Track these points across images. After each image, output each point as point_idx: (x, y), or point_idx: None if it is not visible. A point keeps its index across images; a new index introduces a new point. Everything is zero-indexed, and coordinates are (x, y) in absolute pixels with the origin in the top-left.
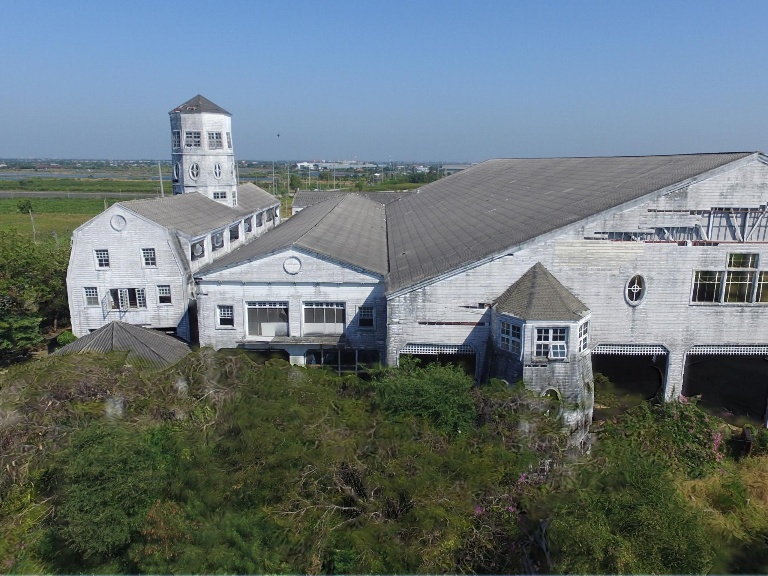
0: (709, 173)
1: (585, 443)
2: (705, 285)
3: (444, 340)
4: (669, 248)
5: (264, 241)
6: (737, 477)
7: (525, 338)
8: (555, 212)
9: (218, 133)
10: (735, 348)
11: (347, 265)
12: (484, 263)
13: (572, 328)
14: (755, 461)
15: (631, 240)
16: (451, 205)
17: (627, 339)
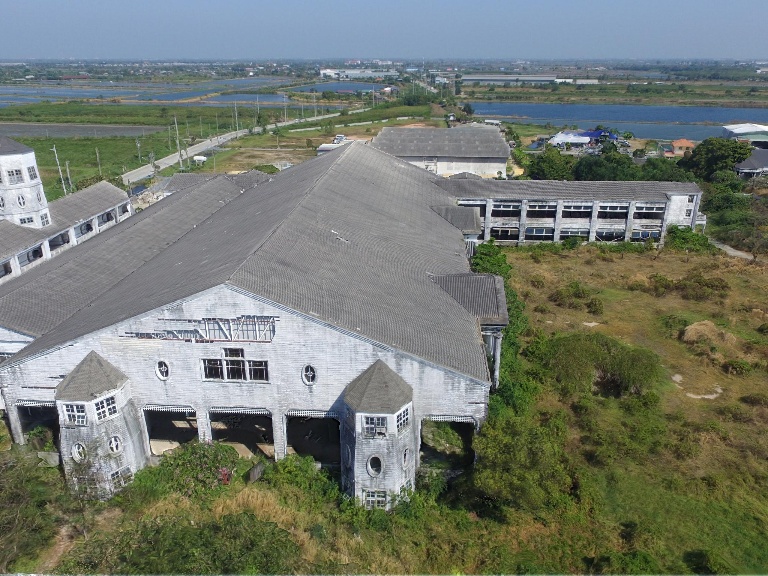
0: (193, 296)
1: (121, 474)
2: (212, 368)
3: (42, 398)
4: (180, 344)
5: (24, 277)
6: (213, 501)
7: (59, 410)
8: (144, 299)
9: (18, 170)
10: (243, 409)
11: (11, 330)
12: (55, 350)
13: (87, 406)
14: (259, 485)
15: (152, 338)
16: (211, 231)
17: (165, 401)
